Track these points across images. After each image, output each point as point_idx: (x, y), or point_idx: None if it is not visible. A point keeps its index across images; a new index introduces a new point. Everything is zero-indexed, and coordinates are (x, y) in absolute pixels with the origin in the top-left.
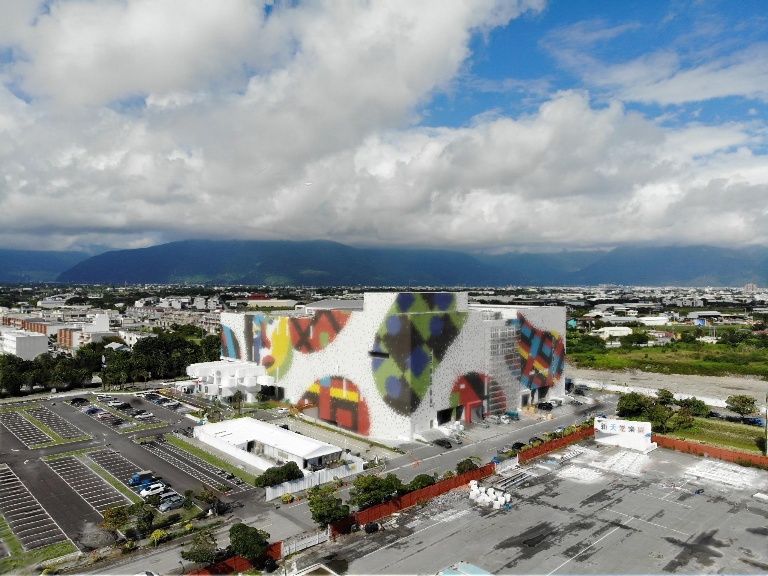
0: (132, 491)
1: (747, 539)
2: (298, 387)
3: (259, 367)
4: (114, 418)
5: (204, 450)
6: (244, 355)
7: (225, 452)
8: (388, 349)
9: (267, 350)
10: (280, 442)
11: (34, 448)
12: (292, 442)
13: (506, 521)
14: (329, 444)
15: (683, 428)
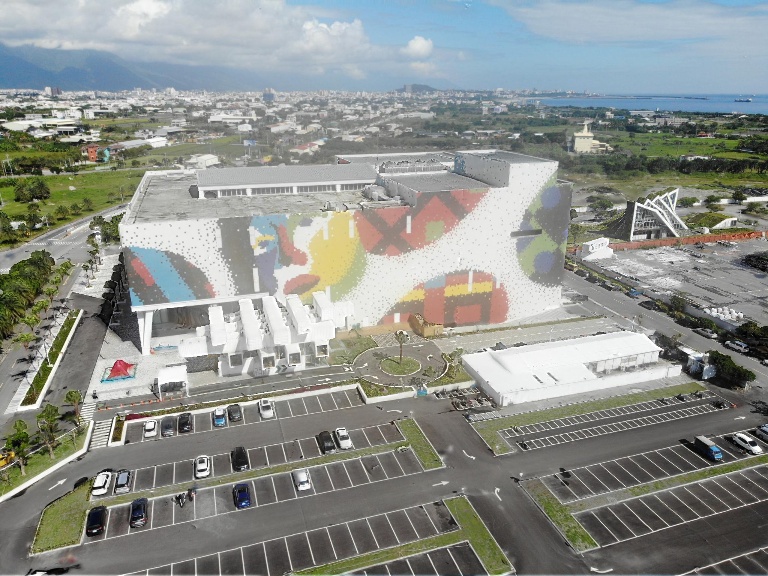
0: (739, 461)
1: None
2: (380, 302)
3: (325, 295)
4: (319, 473)
5: (570, 404)
6: (227, 288)
7: (580, 393)
8: (542, 225)
9: (298, 267)
10: (612, 351)
11: (513, 567)
12: (619, 345)
13: (766, 320)
14: (619, 332)
15: (568, 237)
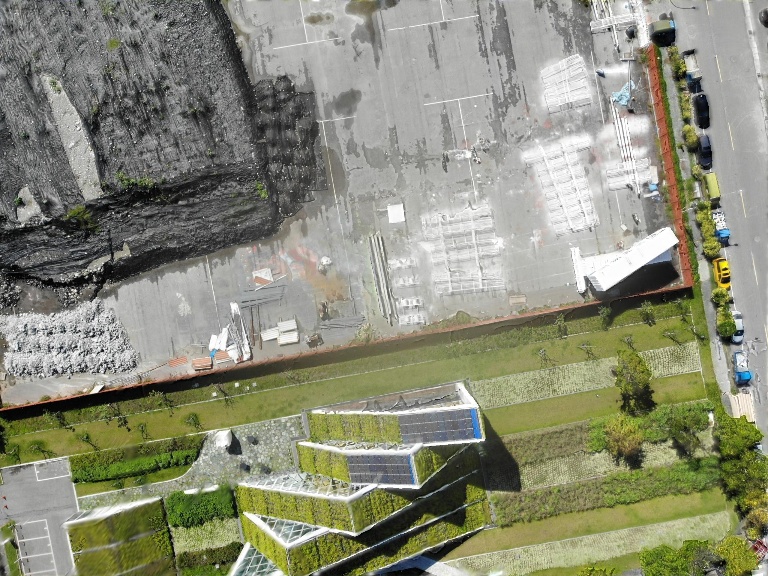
0: None
1: (350, 68)
2: None
3: None
4: None
5: None
6: None
7: None
8: None
9: None
10: None
11: None
12: None
13: None
14: None
15: None
